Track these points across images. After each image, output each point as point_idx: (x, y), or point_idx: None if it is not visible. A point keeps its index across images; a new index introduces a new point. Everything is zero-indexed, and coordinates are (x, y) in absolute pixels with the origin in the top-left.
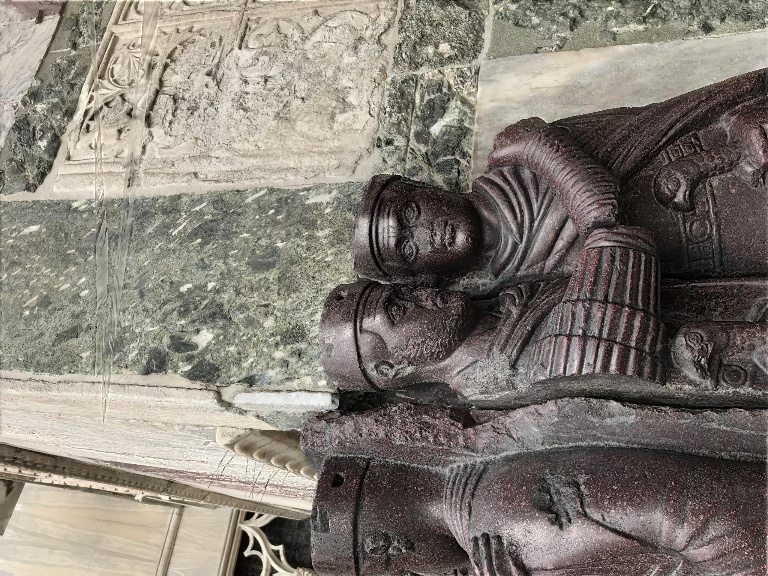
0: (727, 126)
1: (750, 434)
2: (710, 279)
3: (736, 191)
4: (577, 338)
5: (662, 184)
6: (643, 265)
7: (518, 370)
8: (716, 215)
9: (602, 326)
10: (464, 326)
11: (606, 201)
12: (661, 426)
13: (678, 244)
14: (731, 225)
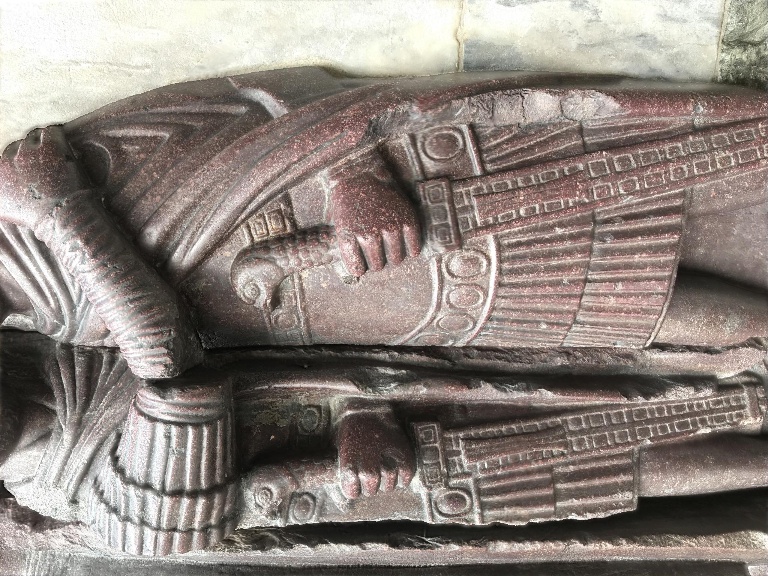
0: (326, 187)
1: (313, 557)
2: (294, 379)
3: (328, 286)
4: (132, 527)
5: (237, 290)
6: (205, 441)
7: (79, 504)
8: (304, 310)
9: (159, 517)
10: (1, 450)
11: (156, 359)
12: (233, 557)
13: (263, 330)
14: (321, 318)
